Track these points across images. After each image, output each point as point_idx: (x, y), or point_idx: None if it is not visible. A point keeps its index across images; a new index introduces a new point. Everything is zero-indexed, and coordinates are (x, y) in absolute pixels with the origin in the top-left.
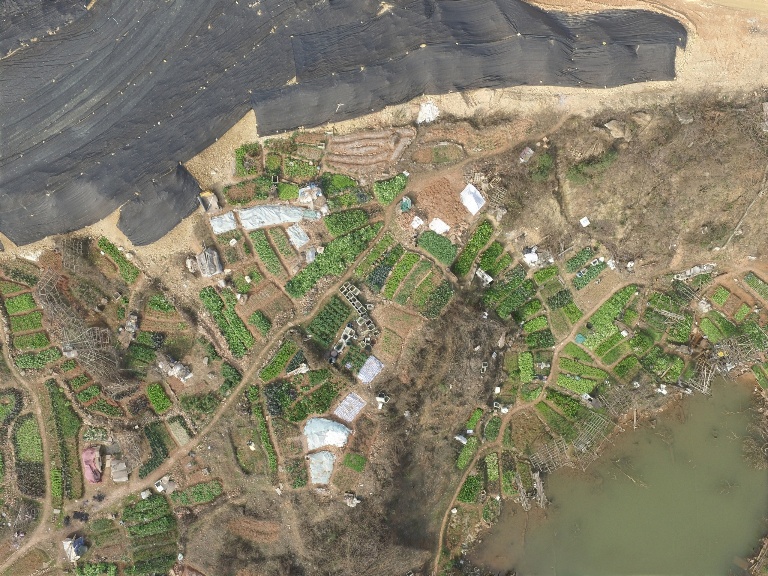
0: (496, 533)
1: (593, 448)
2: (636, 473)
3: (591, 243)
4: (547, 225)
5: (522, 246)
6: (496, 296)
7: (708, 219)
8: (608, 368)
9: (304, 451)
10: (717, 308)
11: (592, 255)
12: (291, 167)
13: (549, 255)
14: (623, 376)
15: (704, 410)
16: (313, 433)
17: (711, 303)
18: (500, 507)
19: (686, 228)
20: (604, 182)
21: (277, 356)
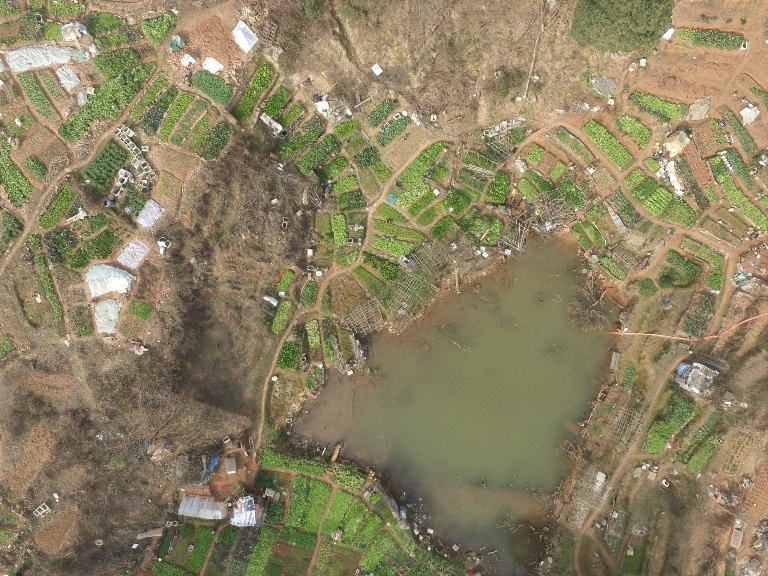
0: (323, 403)
1: (409, 309)
2: (462, 339)
3: (390, 95)
4: (335, 71)
5: (311, 93)
6: (291, 148)
7: (500, 63)
8: (425, 230)
9: (88, 299)
10: (533, 167)
11: (392, 108)
12: (56, 6)
13: (343, 105)
14: (441, 238)
15: (529, 274)
16: (95, 280)
17: (527, 162)
18: (325, 376)
19: (481, 74)
20: (385, 21)
21: (55, 203)
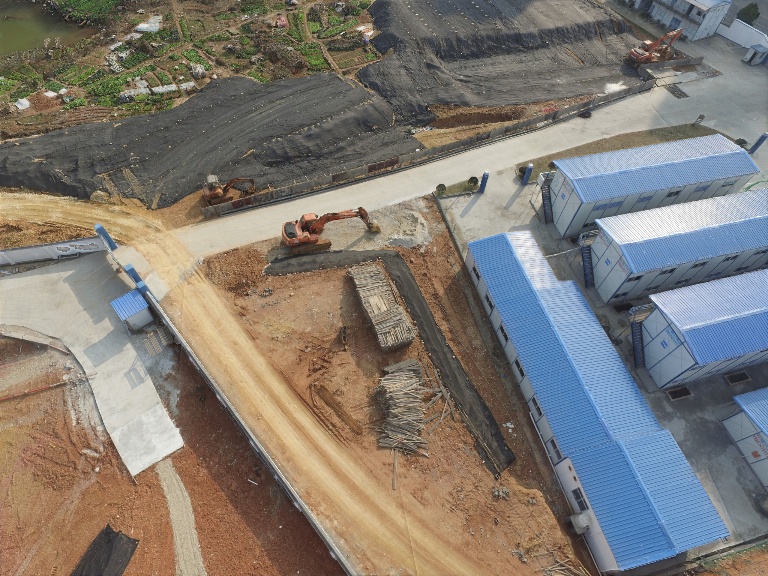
0: None
1: (6, 58)
2: None
3: None
4: None
5: None
6: None
7: None
8: None
9: None
10: None
11: None
12: None
13: None
14: None
15: None
16: None
17: None
18: None
19: None
20: None
21: None
